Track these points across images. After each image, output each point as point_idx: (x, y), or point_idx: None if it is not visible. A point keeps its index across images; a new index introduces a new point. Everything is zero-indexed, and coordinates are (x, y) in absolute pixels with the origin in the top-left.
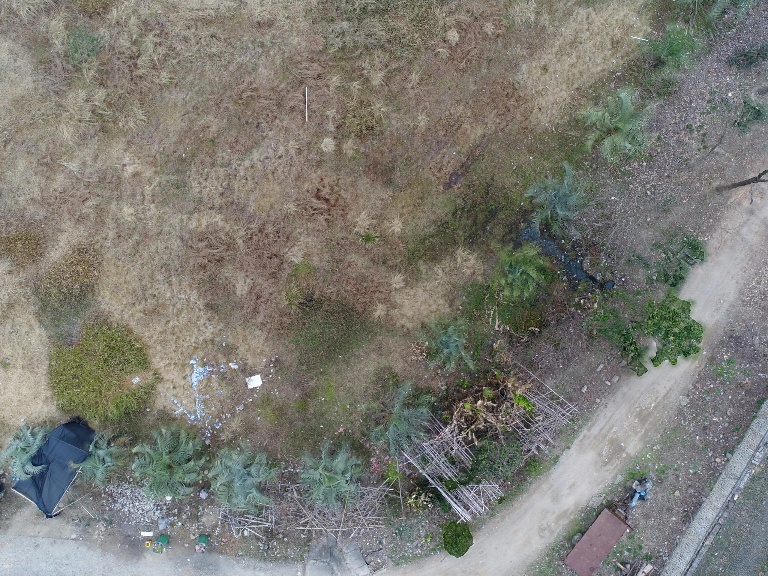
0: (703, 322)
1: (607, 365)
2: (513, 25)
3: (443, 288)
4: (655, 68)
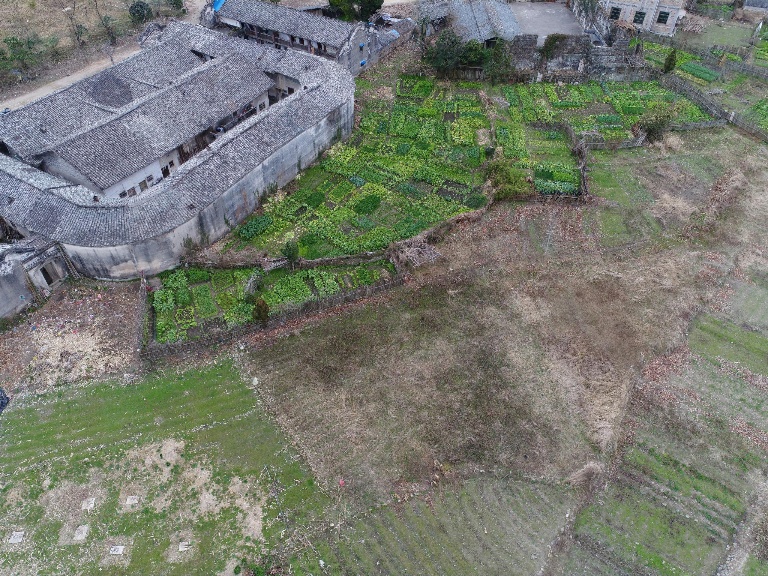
0: None
1: None
2: (40, 39)
3: None
4: (83, 45)
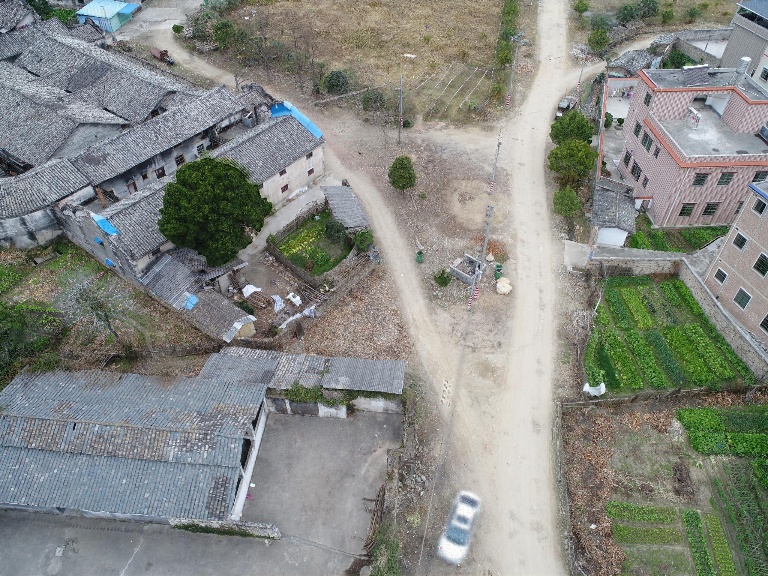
0: None
1: None
2: None
3: None
4: None
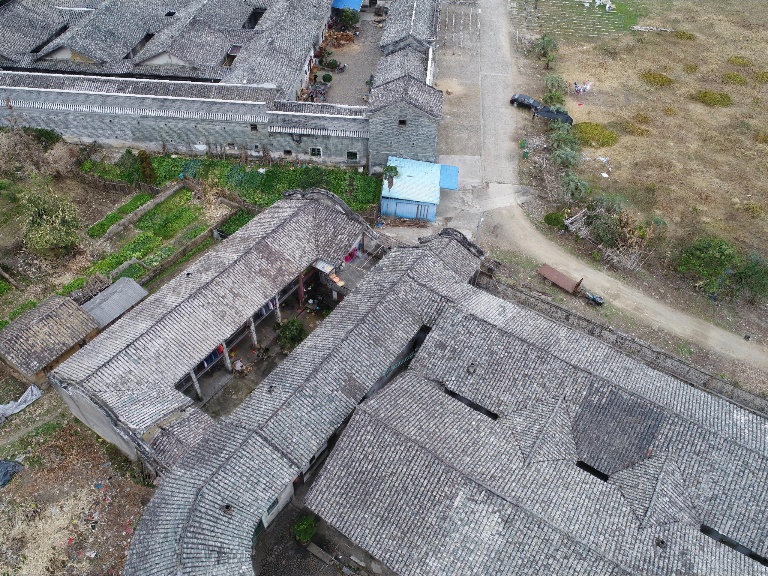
0: (710, 340)
1: (664, 295)
2: None
3: (679, 236)
4: None
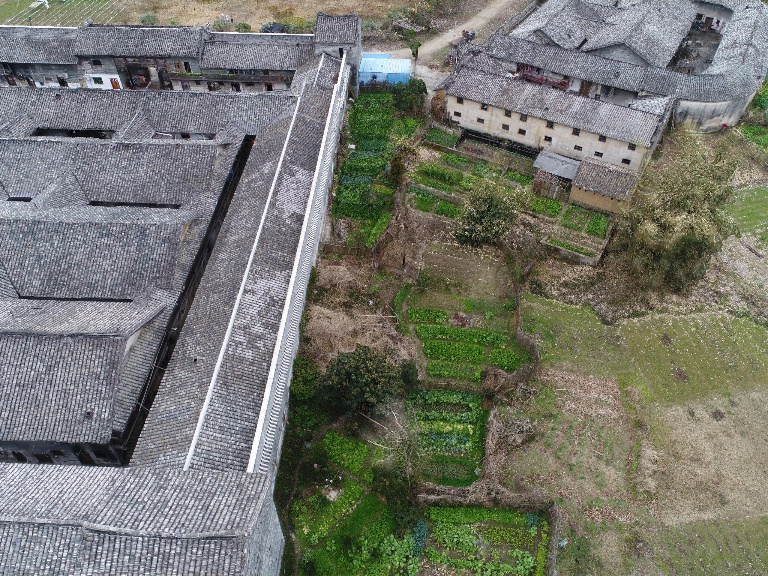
0: None
1: None
2: None
3: None
4: None
